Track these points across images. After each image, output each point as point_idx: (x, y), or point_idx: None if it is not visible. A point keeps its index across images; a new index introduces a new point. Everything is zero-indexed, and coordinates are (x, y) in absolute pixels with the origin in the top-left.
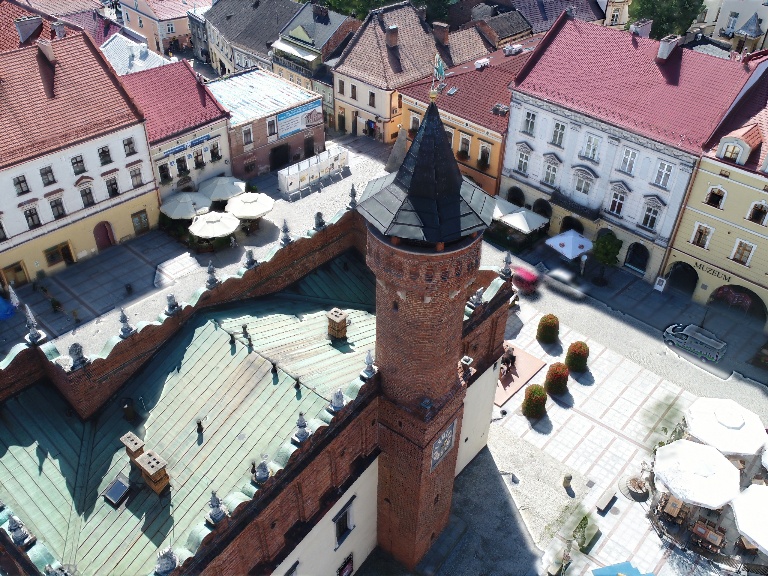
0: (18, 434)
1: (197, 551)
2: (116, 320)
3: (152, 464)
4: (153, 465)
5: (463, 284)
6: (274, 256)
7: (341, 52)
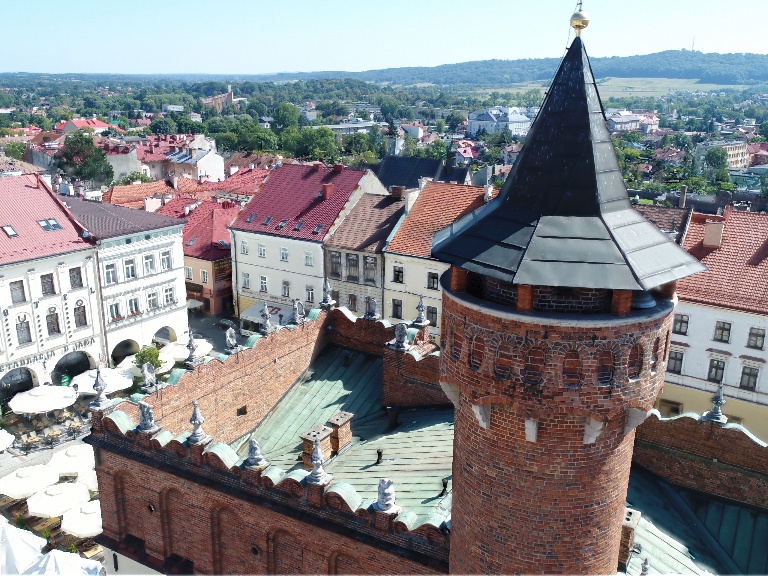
0: (354, 379)
1: (172, 450)
2: None
3: (312, 433)
4: (311, 433)
5: (486, 399)
6: (677, 420)
7: None
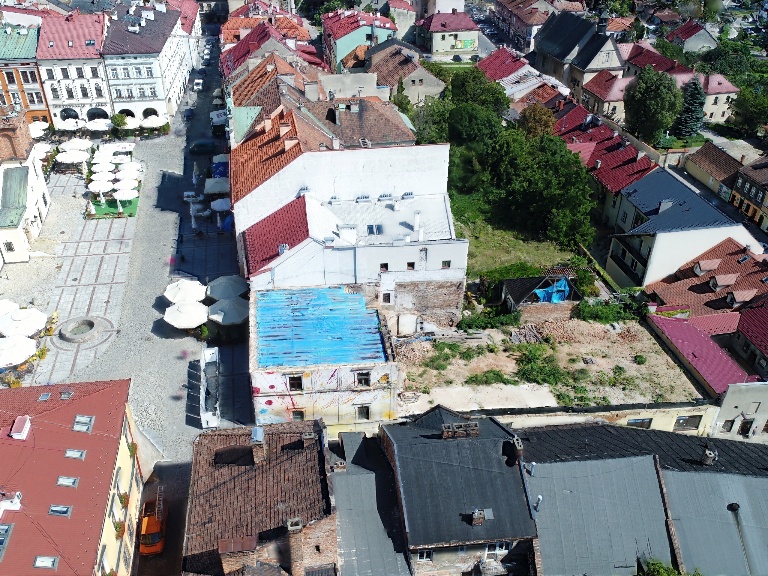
0: None
1: None
2: (166, 252)
3: None
4: None
5: None
6: None
7: (371, 456)
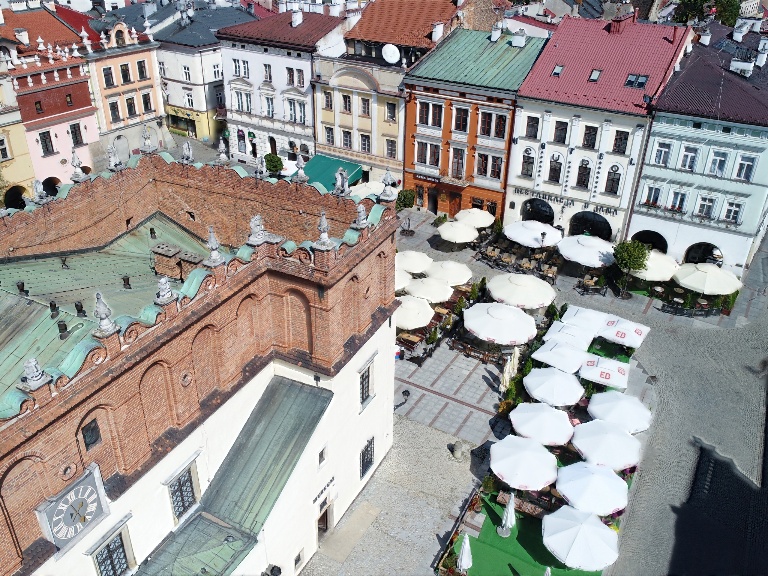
0: None
1: None
2: None
3: (165, 245)
4: (163, 245)
5: None
6: None
7: None
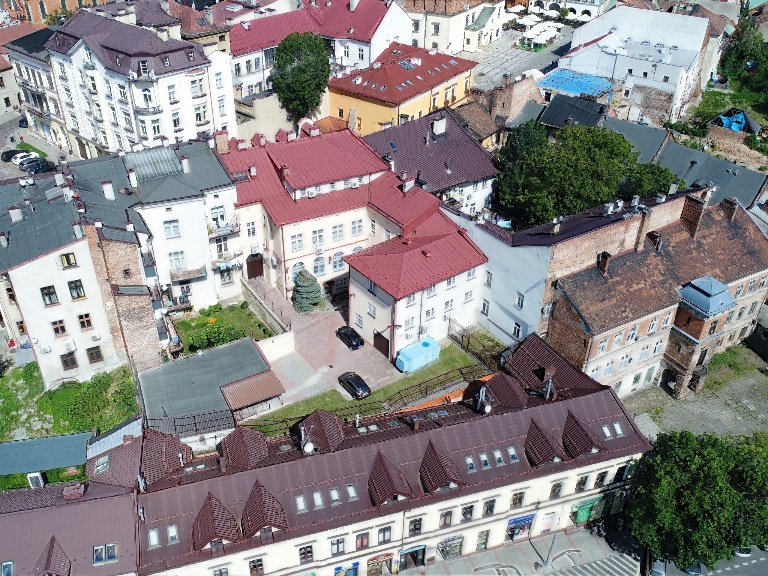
0: None
1: None
2: None
3: None
4: None
5: None
6: None
7: None
